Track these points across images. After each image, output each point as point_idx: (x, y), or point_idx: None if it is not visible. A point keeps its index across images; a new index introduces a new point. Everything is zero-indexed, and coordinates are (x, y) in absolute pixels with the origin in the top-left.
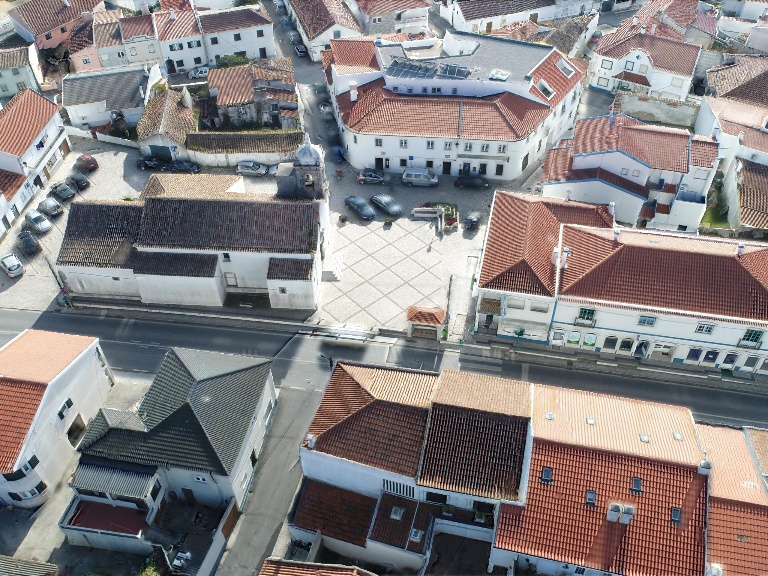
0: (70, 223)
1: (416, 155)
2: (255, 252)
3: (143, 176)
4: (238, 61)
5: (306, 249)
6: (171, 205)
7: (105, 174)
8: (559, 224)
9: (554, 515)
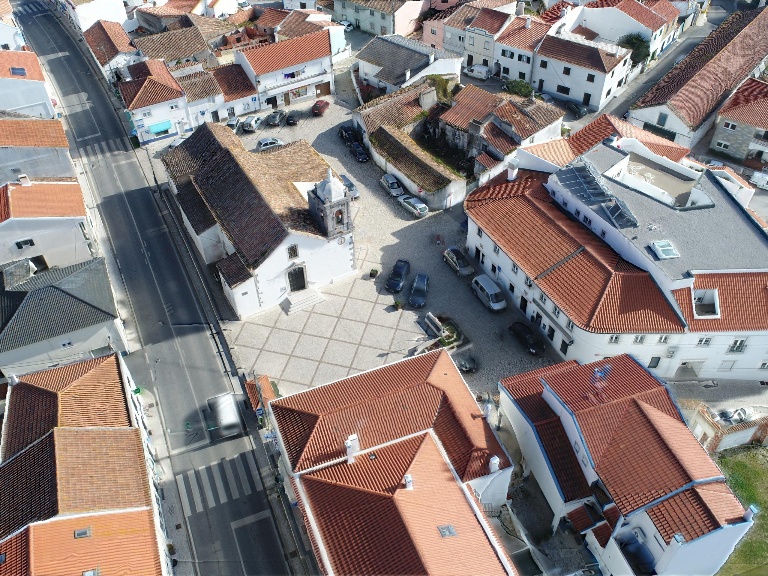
0: (193, 135)
1: (504, 269)
2: (228, 237)
3: (332, 140)
4: (520, 91)
5: (250, 263)
6: (231, 163)
7: (318, 123)
8: (429, 426)
9: None
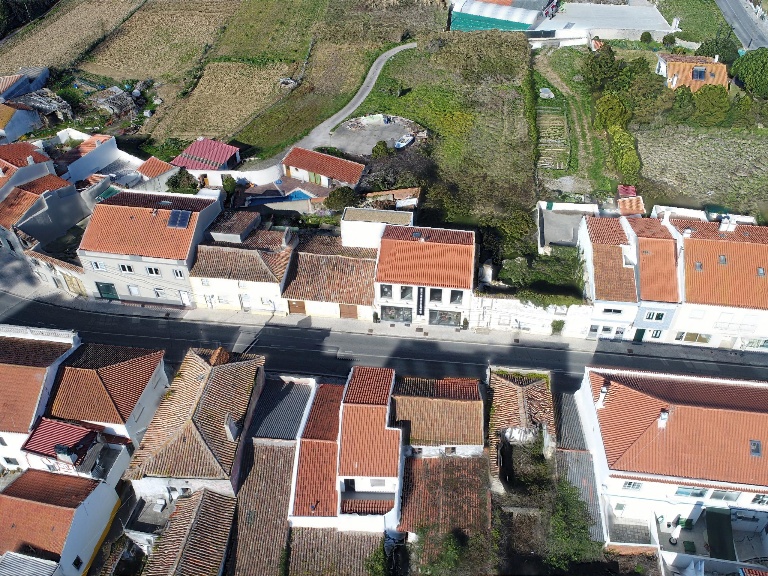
0: None
1: None
2: None
3: None
4: None
5: None
6: None
7: None
8: None
9: (763, 232)
